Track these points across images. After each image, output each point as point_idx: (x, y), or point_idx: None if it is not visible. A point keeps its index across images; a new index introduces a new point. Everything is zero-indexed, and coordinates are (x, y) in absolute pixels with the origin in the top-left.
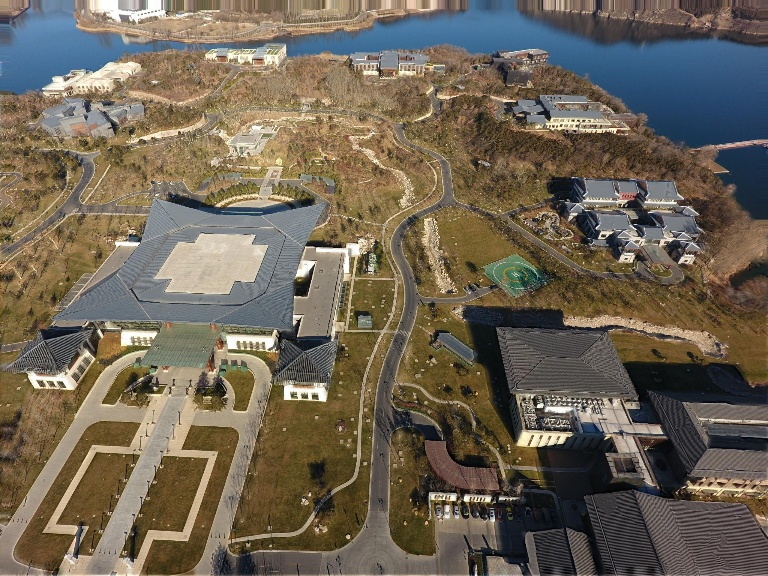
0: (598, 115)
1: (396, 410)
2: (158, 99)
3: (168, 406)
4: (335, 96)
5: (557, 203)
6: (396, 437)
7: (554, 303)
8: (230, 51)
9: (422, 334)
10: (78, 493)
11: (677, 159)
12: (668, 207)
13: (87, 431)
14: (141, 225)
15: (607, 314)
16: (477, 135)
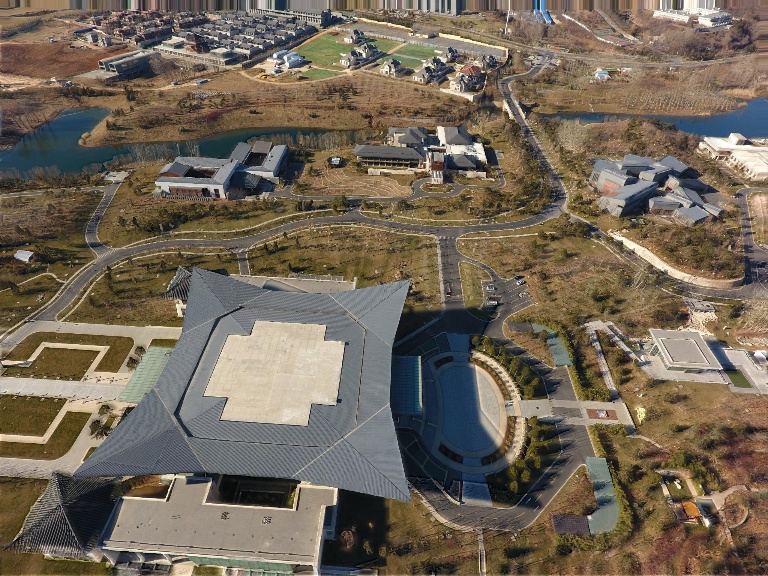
0: None
1: None
2: (759, 223)
3: None
4: None
5: None
6: None
7: None
8: None
9: None
10: (65, 351)
11: None
12: None
13: (127, 338)
14: None
15: None
16: None
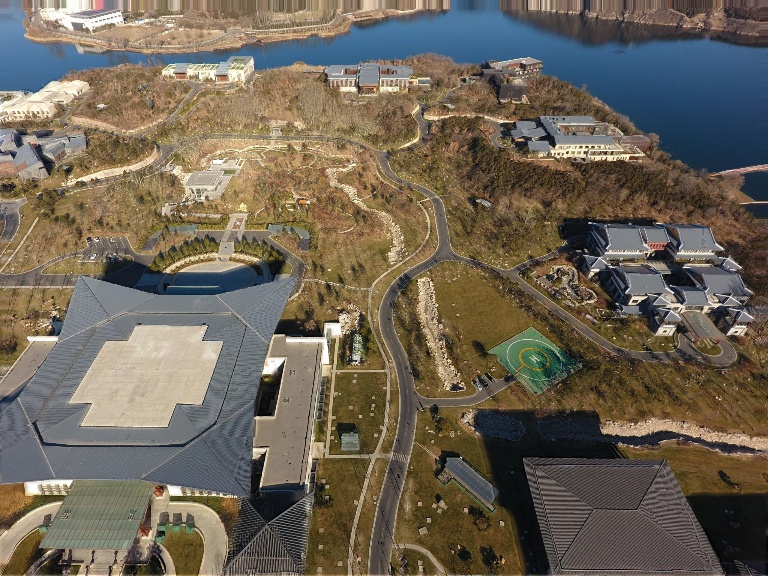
0: (609, 140)
1: None
2: (104, 127)
3: None
4: (309, 118)
5: (573, 255)
6: None
7: (586, 402)
8: (190, 66)
9: (425, 459)
10: None
11: (702, 192)
12: (704, 258)
13: None
14: (65, 307)
15: (654, 416)
16: (473, 167)
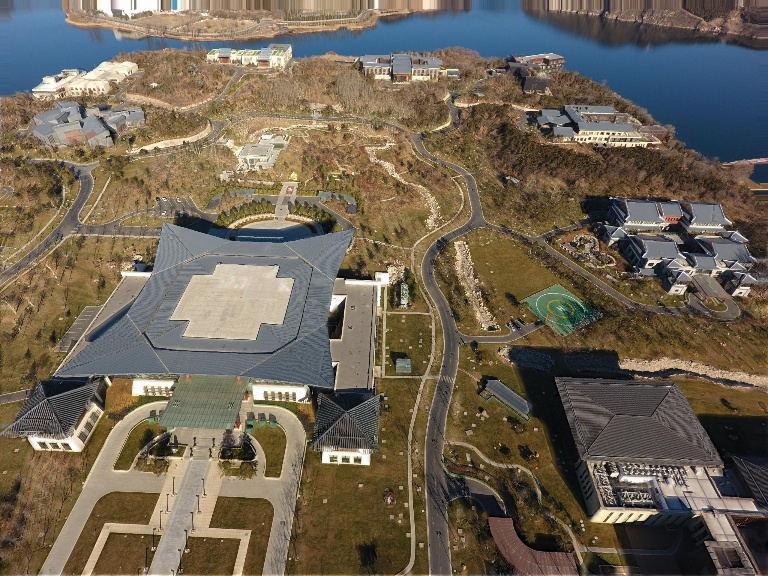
0: (628, 128)
1: (449, 476)
2: (158, 103)
3: (190, 472)
4: (347, 102)
5: (595, 226)
6: (453, 510)
7: (607, 343)
8: (233, 51)
9: (468, 381)
10: None
11: (714, 177)
12: (714, 231)
13: (98, 505)
14: (149, 251)
15: (666, 356)
16: (502, 148)
